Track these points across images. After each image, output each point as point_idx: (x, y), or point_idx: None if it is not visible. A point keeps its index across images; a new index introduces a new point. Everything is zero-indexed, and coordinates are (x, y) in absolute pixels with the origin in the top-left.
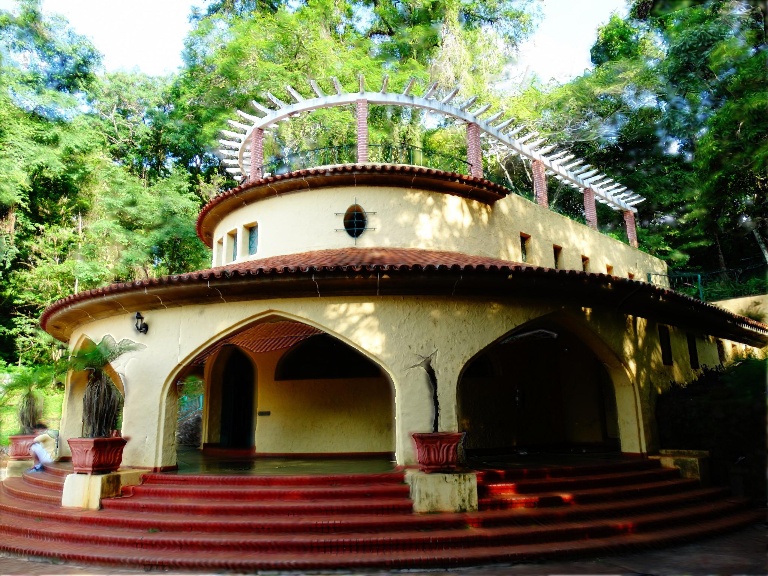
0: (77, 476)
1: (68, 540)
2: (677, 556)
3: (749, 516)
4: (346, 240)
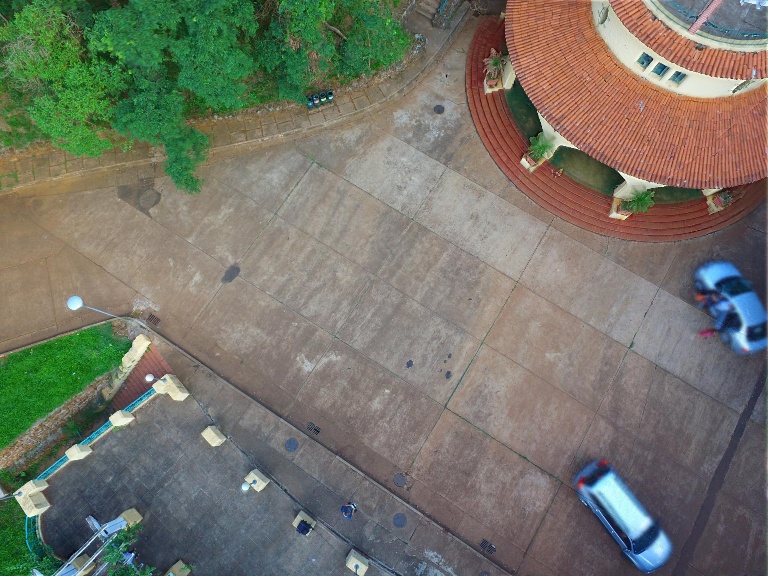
0: (618, 214)
1: None
2: (757, 214)
3: None
4: None
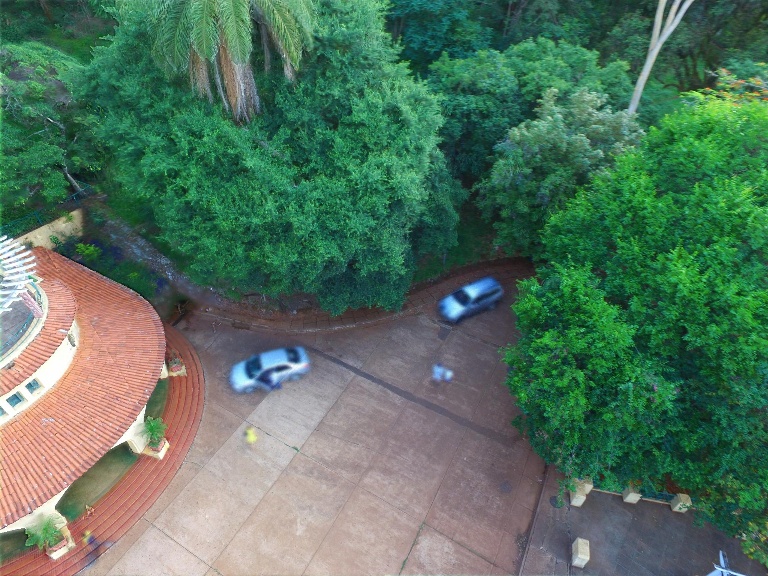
0: None
1: (184, 445)
2: None
3: (170, 327)
4: (74, 349)
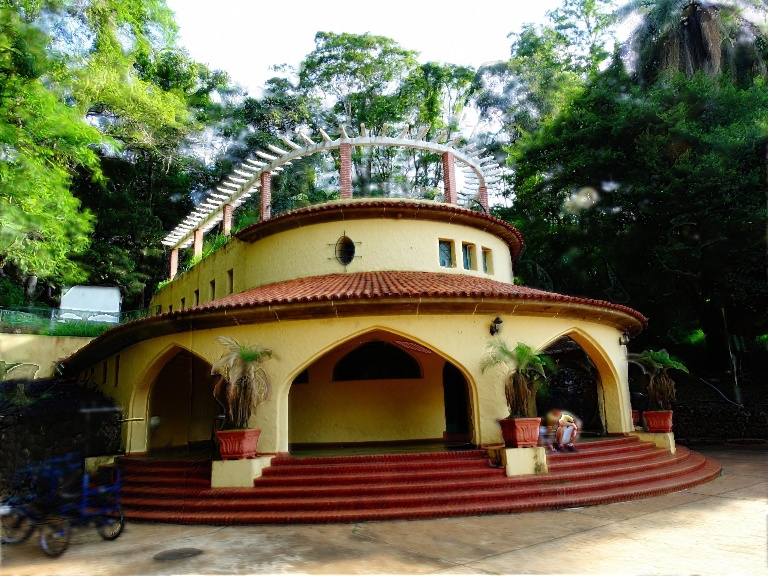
0: None
1: None
2: None
3: None
4: None
